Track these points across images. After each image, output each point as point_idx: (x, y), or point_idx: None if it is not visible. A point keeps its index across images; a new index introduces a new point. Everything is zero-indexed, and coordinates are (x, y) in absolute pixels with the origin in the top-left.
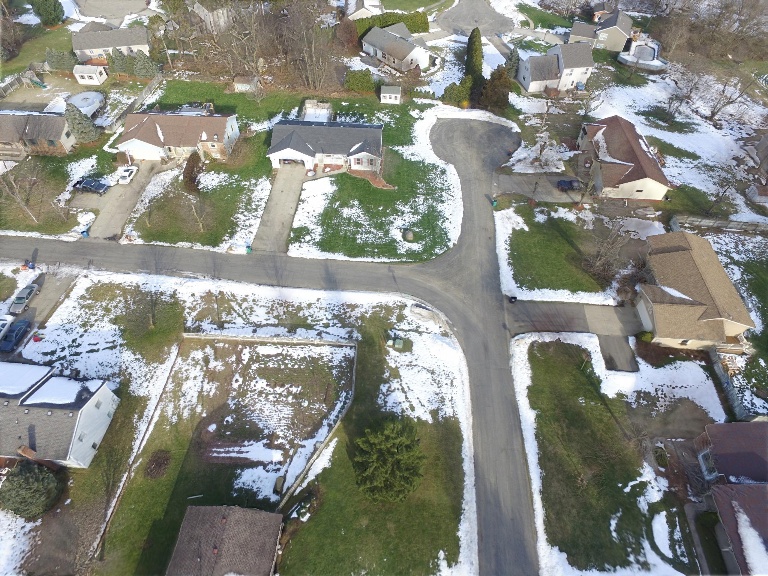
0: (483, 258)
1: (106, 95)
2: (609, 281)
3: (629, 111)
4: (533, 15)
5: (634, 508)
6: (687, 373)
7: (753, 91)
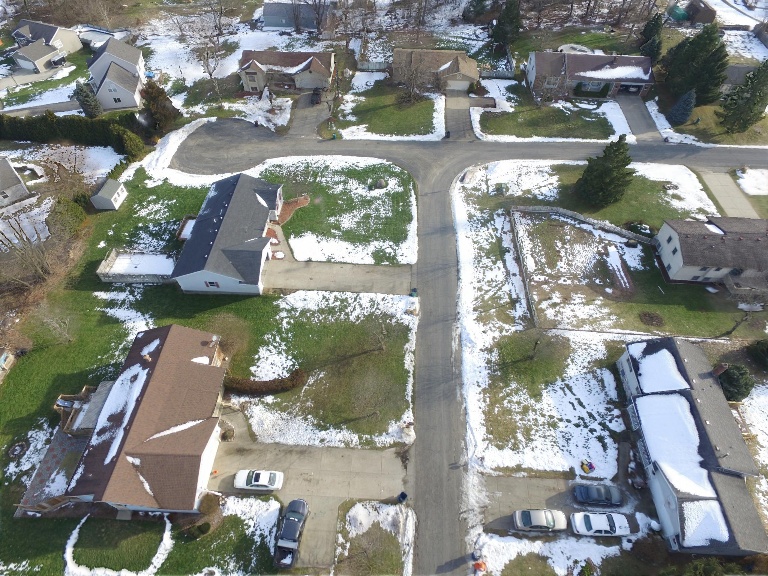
0: (403, 147)
1: None
2: (423, 96)
3: (196, 62)
4: None
5: (578, 112)
6: (489, 84)
7: (185, 11)
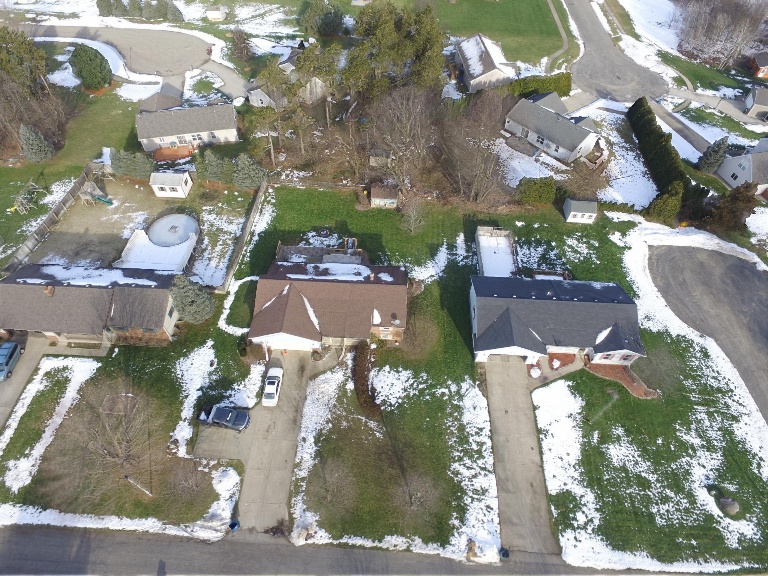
0: None
1: (197, 216)
2: None
3: None
4: (684, 69)
5: None
6: None
7: None
